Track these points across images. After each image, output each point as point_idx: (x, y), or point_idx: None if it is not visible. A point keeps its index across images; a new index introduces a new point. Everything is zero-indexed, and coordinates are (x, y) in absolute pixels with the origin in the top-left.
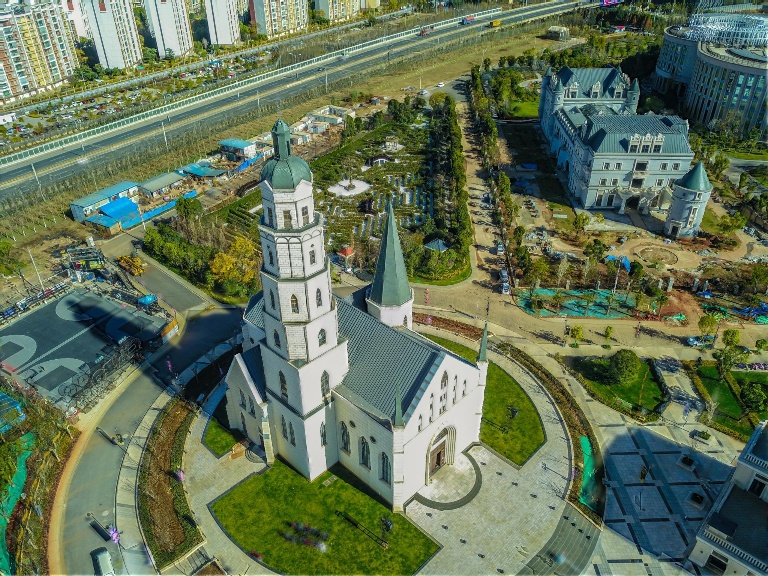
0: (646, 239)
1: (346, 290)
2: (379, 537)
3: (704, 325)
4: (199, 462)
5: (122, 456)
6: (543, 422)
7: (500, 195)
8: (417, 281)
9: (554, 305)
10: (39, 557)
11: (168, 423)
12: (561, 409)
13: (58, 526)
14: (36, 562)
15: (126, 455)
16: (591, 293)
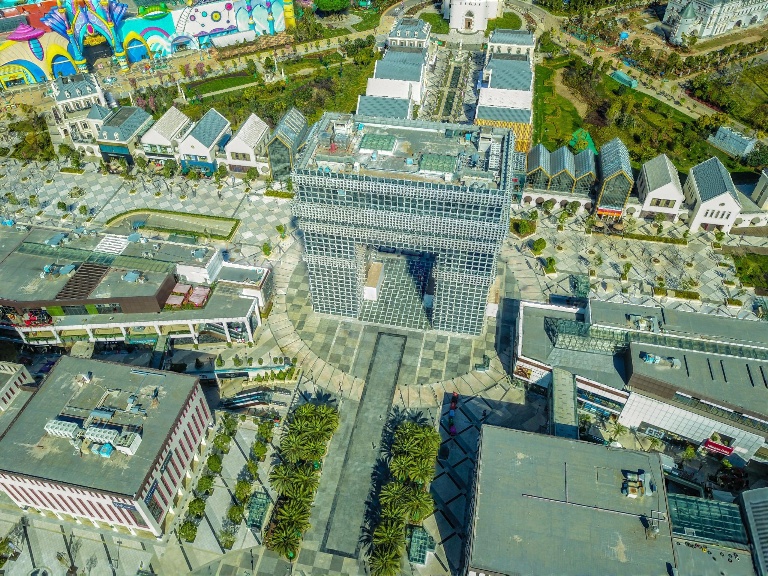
0: (657, 38)
1: (523, 3)
2: (441, 28)
3: (586, 42)
4: (430, 8)
5: (420, 2)
6: None
7: (630, 1)
8: (547, 10)
9: (571, 31)
10: (390, 5)
11: (435, 1)
12: None
13: (398, 4)
14: (389, 5)
15: (421, 2)
16: (591, 35)
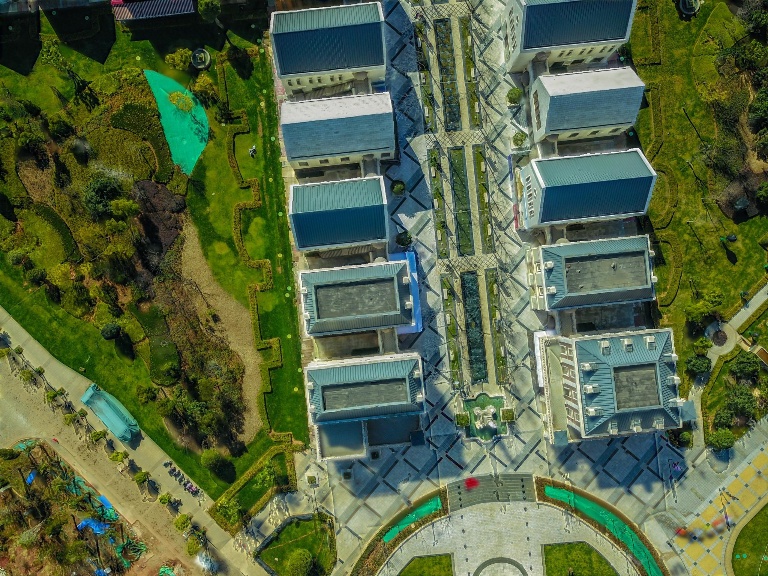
0: None
1: None
2: None
3: (198, 548)
4: None
5: None
6: (400, 571)
7: None
8: None
9: None
10: None
11: None
12: (375, 571)
13: None
14: None
15: None
16: None
